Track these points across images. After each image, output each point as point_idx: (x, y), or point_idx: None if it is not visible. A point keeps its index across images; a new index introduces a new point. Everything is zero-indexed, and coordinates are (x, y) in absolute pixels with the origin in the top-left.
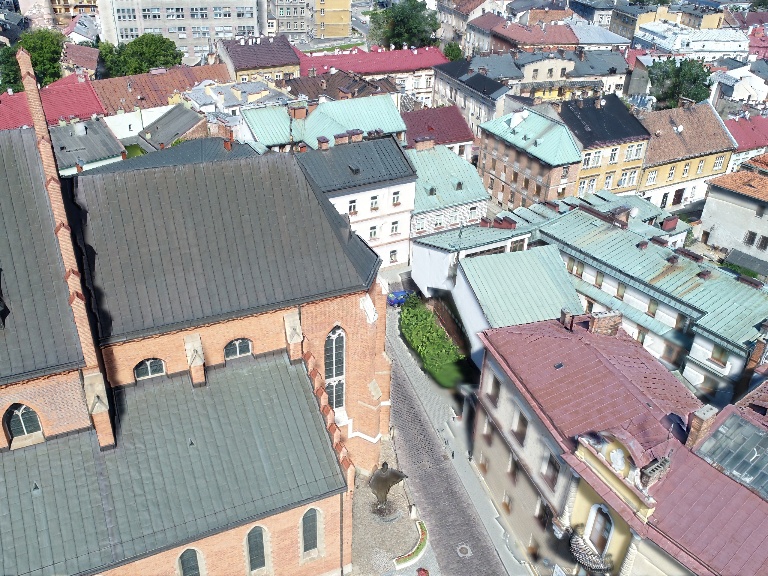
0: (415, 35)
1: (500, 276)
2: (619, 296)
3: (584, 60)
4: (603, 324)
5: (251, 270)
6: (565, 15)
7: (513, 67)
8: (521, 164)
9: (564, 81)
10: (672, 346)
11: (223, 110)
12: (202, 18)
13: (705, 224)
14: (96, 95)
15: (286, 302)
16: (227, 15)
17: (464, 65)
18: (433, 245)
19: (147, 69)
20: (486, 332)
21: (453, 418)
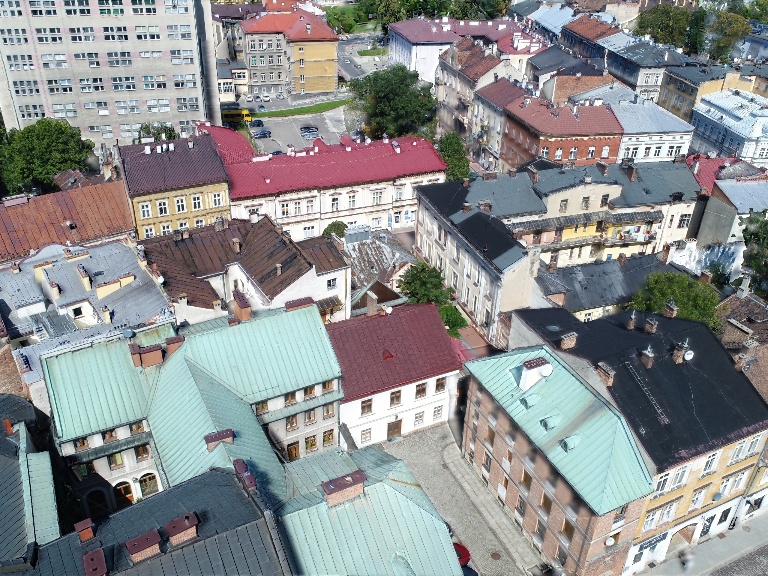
0: (403, 116)
1: None
2: None
3: (635, 179)
4: None
5: None
6: (603, 82)
7: (531, 195)
8: (537, 468)
9: (605, 212)
10: None
11: (57, 310)
12: (128, 90)
13: None
14: None
15: None
16: (161, 85)
17: (458, 193)
18: None
19: (40, 168)
20: None
21: None
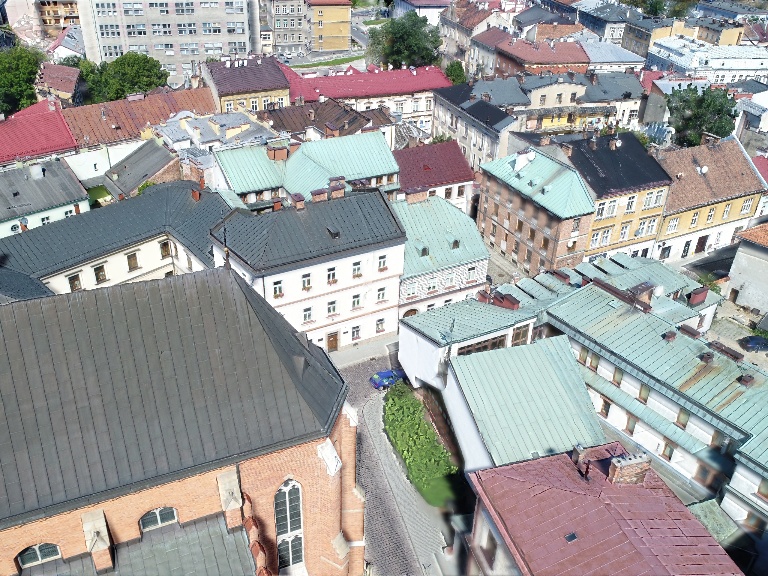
0: (415, 53)
1: (499, 380)
2: (641, 399)
3: (596, 84)
4: (627, 472)
5: (172, 422)
6: (575, 30)
7: (519, 92)
8: (526, 213)
9: (574, 107)
10: (707, 468)
11: (199, 146)
12: (190, 34)
13: (734, 281)
14: (66, 125)
15: (219, 461)
16: (217, 31)
17: (466, 90)
18: (421, 332)
19: (129, 90)
20: (479, 475)
21: (442, 548)
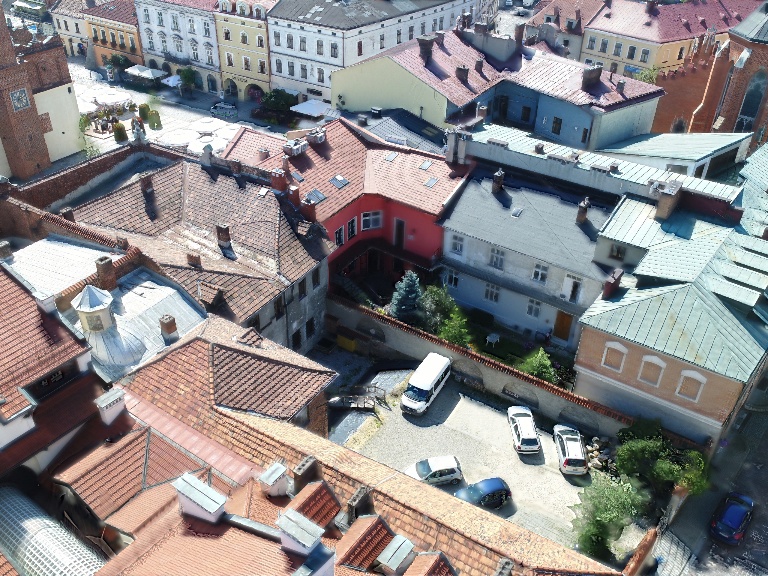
0: None
1: None
2: None
3: None
4: None
5: None
6: None
7: None
8: None
9: None
10: None
11: None
12: None
13: None
14: None
15: None
16: None
17: None
18: None
19: None
20: None
21: None
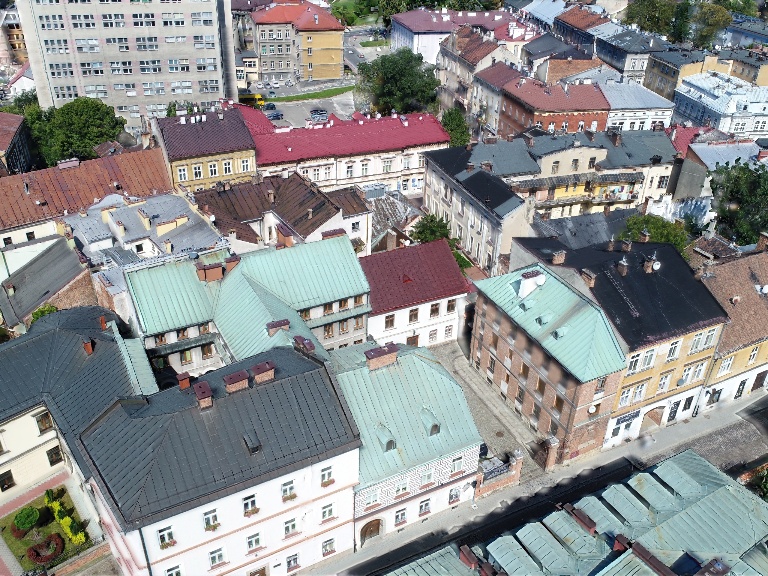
0: (408, 95)
1: None
2: None
3: (619, 145)
4: None
5: None
6: (592, 65)
7: (526, 158)
8: (533, 358)
9: (593, 174)
10: None
11: (123, 246)
12: (154, 72)
13: None
14: None
15: None
16: (185, 68)
17: (463, 156)
18: None
19: (78, 142)
20: None
21: None
